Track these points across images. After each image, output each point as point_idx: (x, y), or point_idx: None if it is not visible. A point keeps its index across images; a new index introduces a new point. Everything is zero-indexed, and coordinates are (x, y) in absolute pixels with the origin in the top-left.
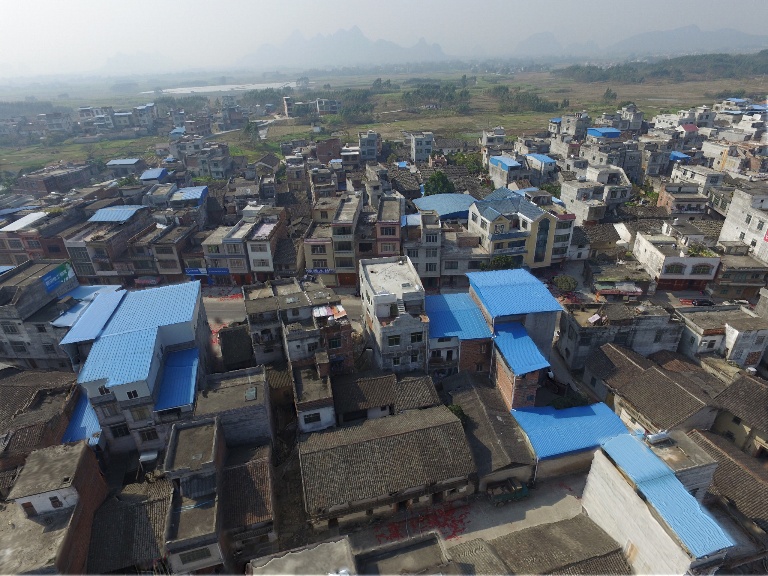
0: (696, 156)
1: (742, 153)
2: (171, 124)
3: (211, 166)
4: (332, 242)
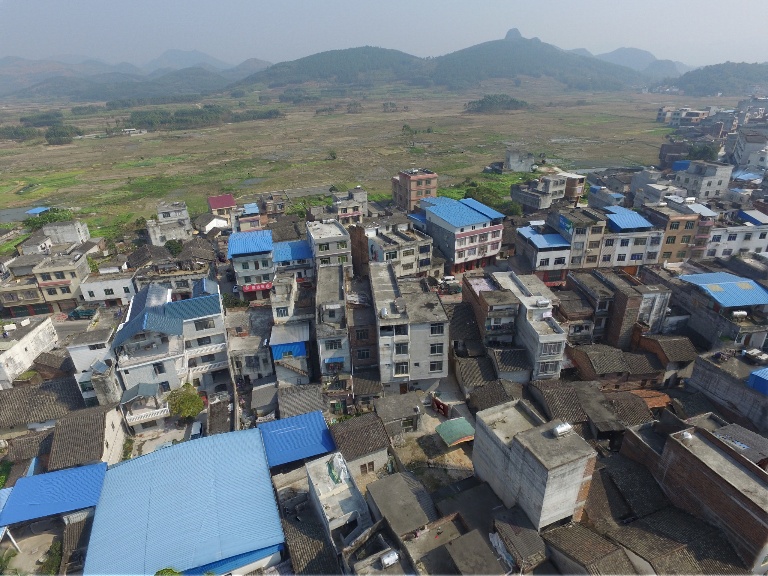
0: None
1: None
2: None
3: None
4: None
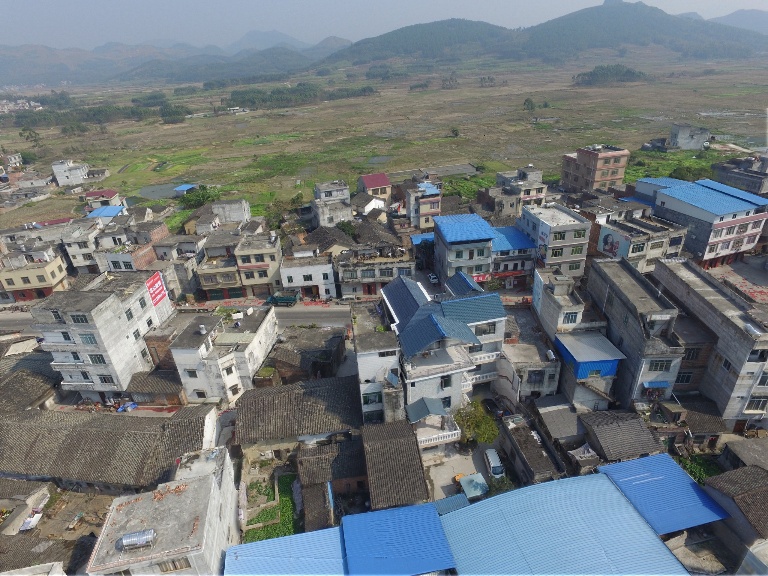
0: None
1: None
2: None
3: None
4: None
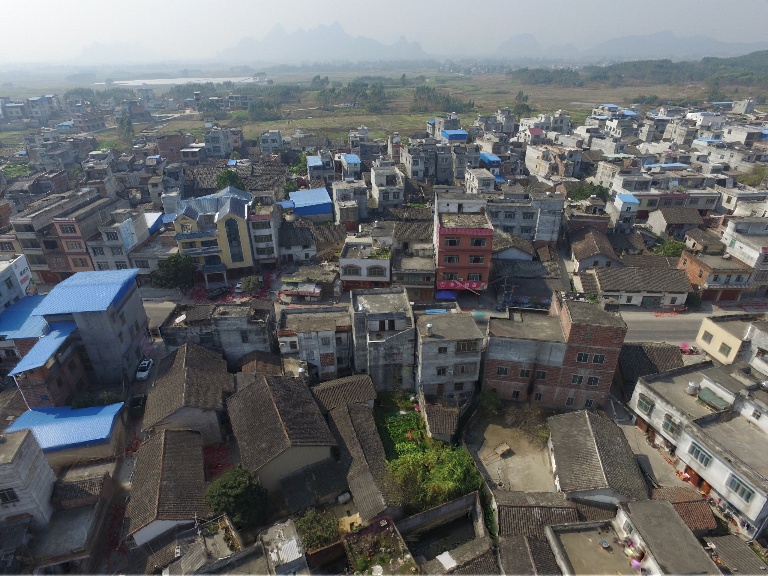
0: (511, 159)
1: (553, 157)
2: (69, 116)
3: (47, 160)
4: (17, 239)
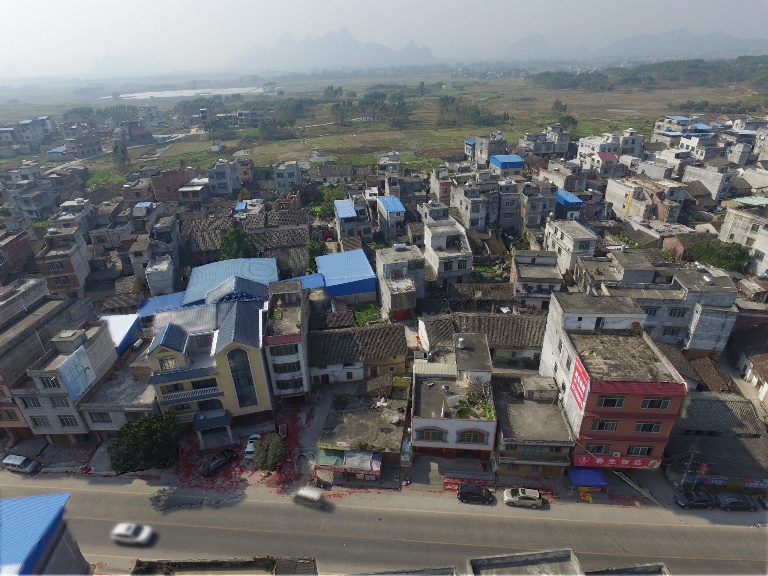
0: (593, 199)
1: (648, 196)
2: None
3: (21, 204)
4: None
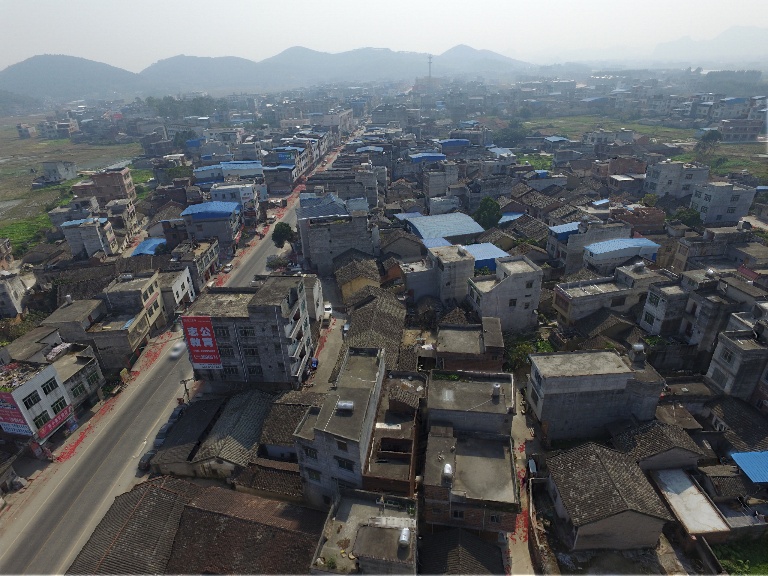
0: None
1: None
2: None
3: None
4: None
